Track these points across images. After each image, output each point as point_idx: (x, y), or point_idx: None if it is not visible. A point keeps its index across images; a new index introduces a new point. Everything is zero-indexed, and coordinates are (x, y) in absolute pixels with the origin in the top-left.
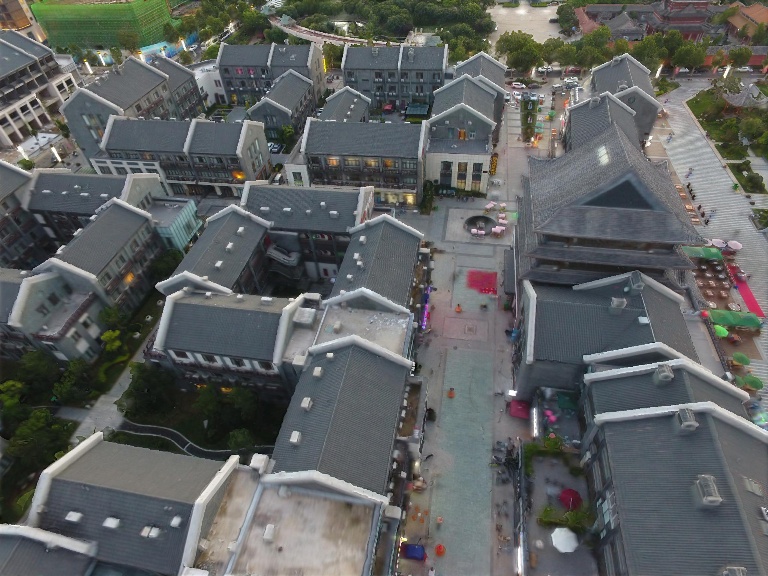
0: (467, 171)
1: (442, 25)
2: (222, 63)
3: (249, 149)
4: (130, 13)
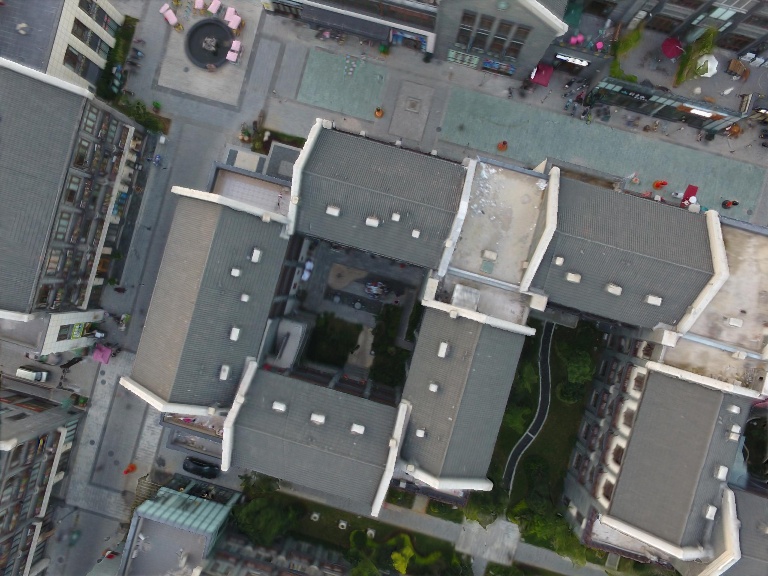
0: (87, 27)
1: None
2: None
3: None
4: None
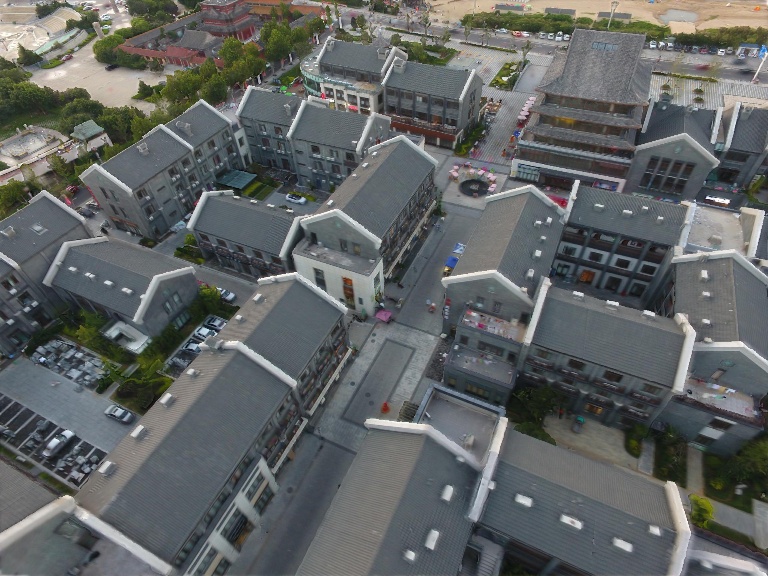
0: None
1: None
2: None
3: None
4: None
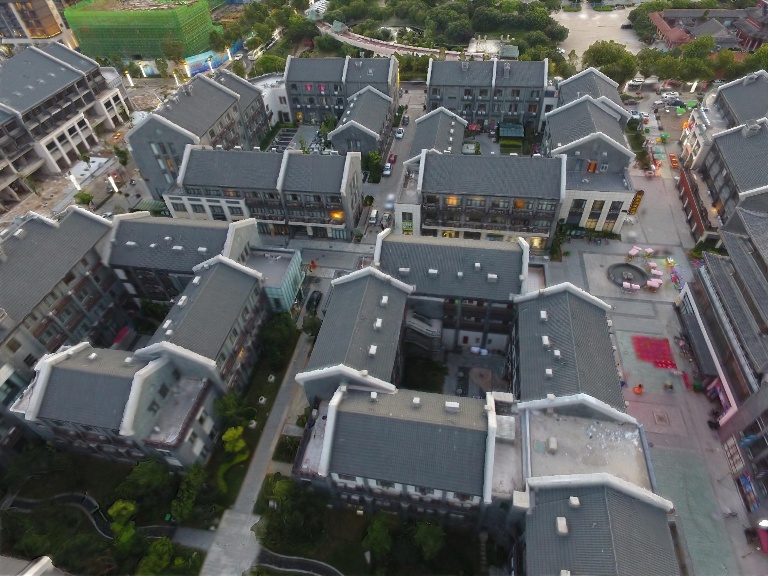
0: (602, 210)
1: (505, 31)
2: (290, 78)
3: (350, 185)
4: (174, 20)
